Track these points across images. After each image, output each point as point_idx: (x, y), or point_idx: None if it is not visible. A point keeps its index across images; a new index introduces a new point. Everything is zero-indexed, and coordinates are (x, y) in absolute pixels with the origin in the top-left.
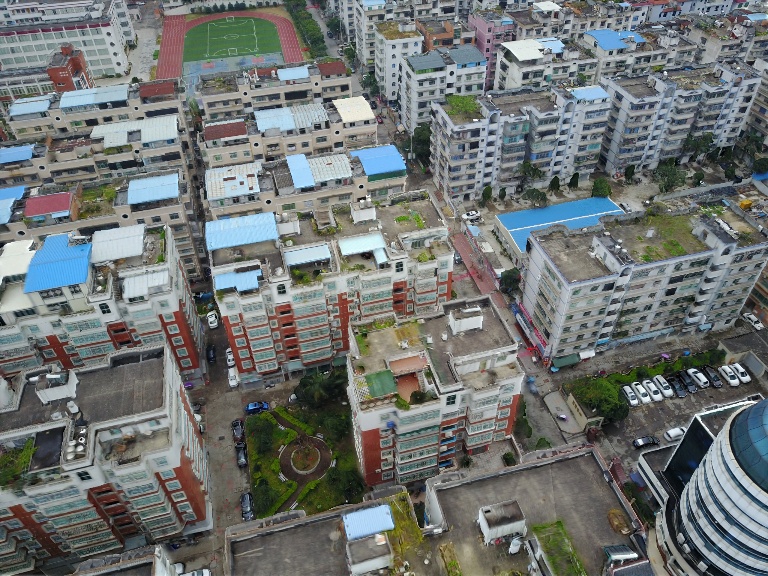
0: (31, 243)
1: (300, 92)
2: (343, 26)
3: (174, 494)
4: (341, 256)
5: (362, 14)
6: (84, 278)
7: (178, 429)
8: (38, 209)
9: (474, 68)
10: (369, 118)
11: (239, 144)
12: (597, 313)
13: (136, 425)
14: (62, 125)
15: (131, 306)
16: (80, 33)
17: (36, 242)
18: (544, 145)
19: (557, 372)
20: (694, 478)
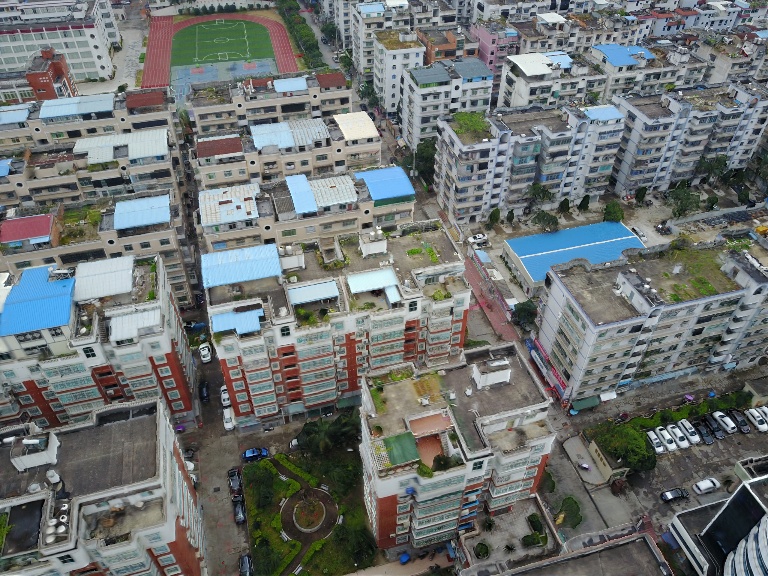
0: (7, 277)
1: (298, 105)
2: (338, 32)
3: (167, 568)
4: (350, 294)
5: (360, 21)
6: (66, 320)
7: (173, 498)
8: (15, 234)
9: (480, 83)
10: (373, 136)
11: (234, 162)
12: (622, 355)
13: (126, 497)
14: (42, 136)
15: (119, 349)
16: (62, 34)
17: (12, 270)
18: (555, 166)
19: (576, 415)
20: (741, 551)
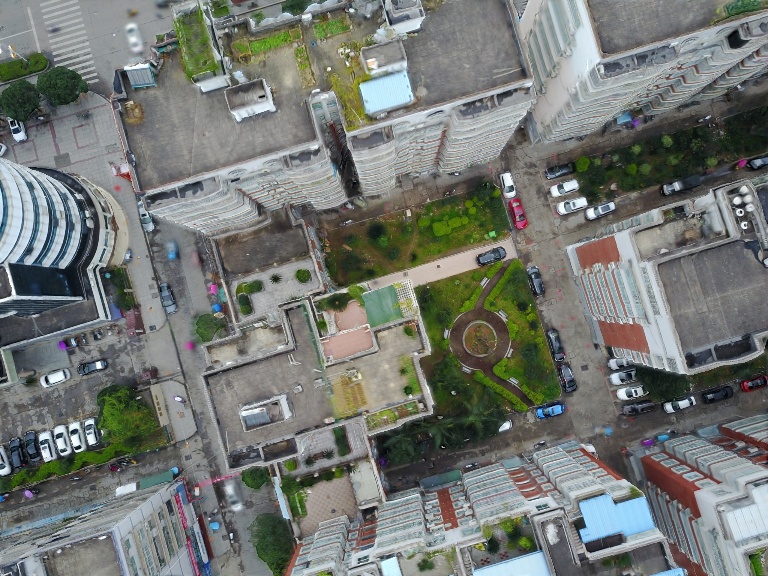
0: None
1: None
2: None
3: None
4: None
5: None
6: None
7: (630, 267)
8: None
9: None
10: None
11: None
12: None
13: None
14: None
15: None
16: None
17: None
18: None
19: None
20: (50, 254)
